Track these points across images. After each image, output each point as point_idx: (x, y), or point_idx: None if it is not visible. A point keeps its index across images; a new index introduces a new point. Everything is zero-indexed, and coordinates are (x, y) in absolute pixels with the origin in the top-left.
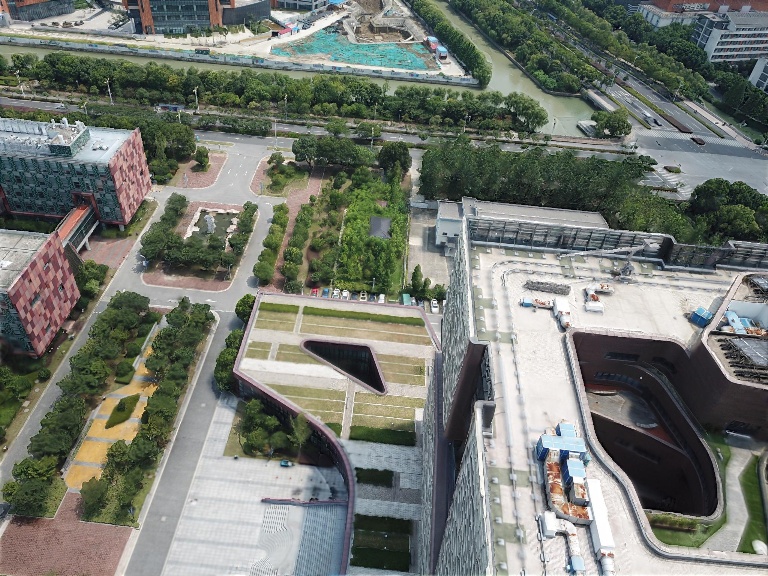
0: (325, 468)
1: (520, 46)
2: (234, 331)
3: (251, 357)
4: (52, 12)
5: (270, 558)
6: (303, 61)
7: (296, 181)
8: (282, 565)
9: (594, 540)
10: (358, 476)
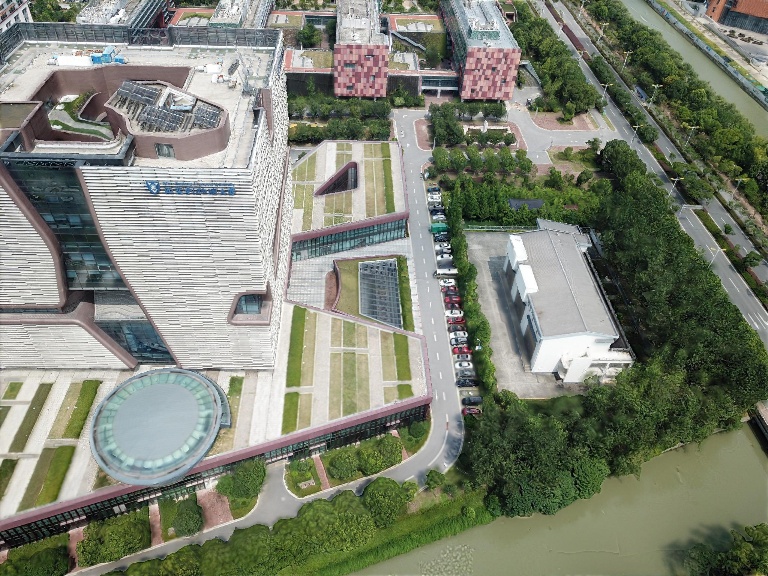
0: None
1: None
2: None
3: (337, 145)
4: (756, 28)
5: None
6: None
7: (581, 165)
8: None
9: None
10: None
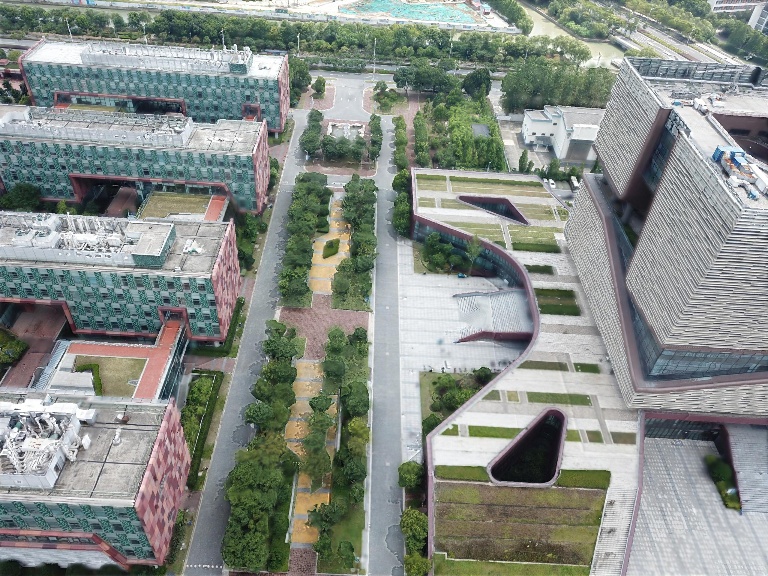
0: (491, 278)
1: (552, 2)
2: (402, 193)
3: (423, 206)
4: None
5: (472, 325)
6: (369, 18)
7: (399, 104)
8: (484, 327)
9: (760, 187)
10: (528, 269)
